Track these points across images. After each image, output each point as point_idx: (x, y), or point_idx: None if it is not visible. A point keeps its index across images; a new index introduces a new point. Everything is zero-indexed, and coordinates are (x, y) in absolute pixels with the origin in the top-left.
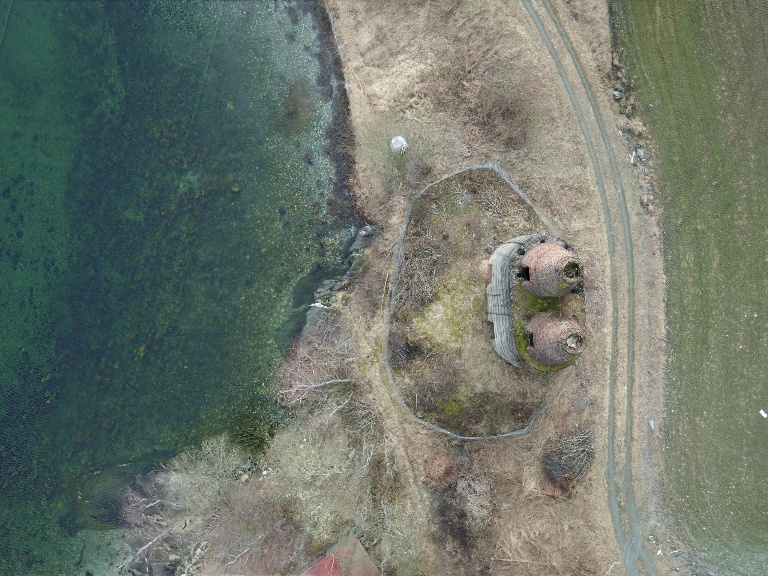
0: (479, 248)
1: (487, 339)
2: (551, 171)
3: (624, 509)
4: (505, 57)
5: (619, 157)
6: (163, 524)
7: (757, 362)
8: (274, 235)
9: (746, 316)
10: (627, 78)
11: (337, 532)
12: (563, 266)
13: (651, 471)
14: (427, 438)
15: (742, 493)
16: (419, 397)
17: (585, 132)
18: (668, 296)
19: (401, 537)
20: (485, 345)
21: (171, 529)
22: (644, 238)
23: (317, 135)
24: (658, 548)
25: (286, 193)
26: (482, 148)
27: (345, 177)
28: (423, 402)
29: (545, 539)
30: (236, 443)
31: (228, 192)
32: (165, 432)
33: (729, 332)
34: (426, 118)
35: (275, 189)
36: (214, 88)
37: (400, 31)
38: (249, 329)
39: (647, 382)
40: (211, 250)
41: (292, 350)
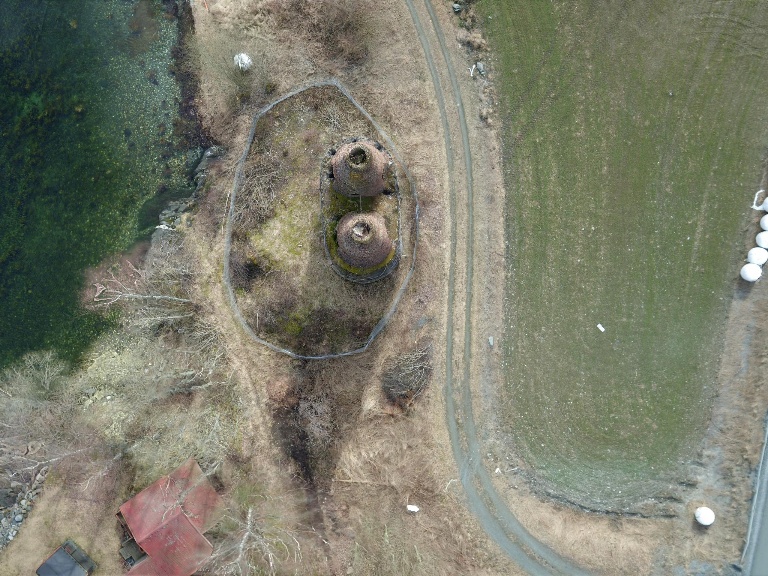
0: (316, 163)
1: (325, 255)
2: (391, 85)
3: (462, 426)
4: None
5: (458, 70)
6: (5, 450)
7: (595, 275)
8: (119, 157)
9: (584, 229)
10: None
11: (179, 456)
12: (349, 152)
13: (490, 388)
14: (270, 359)
15: (580, 409)
16: (259, 317)
17: (424, 45)
18: (507, 210)
19: (240, 458)
20: (323, 261)
21: (13, 455)
22: (484, 152)
23: (162, 55)
24: (496, 466)
25: (131, 114)
26: (326, 65)
27: (190, 97)
28: (263, 321)
29: (384, 458)
30: None
31: (73, 113)
32: (9, 358)
33: (567, 246)
34: (270, 35)
35: (120, 110)
36: (58, 7)
37: None
38: (94, 252)
39: (486, 298)
40: (56, 172)
41: (137, 273)
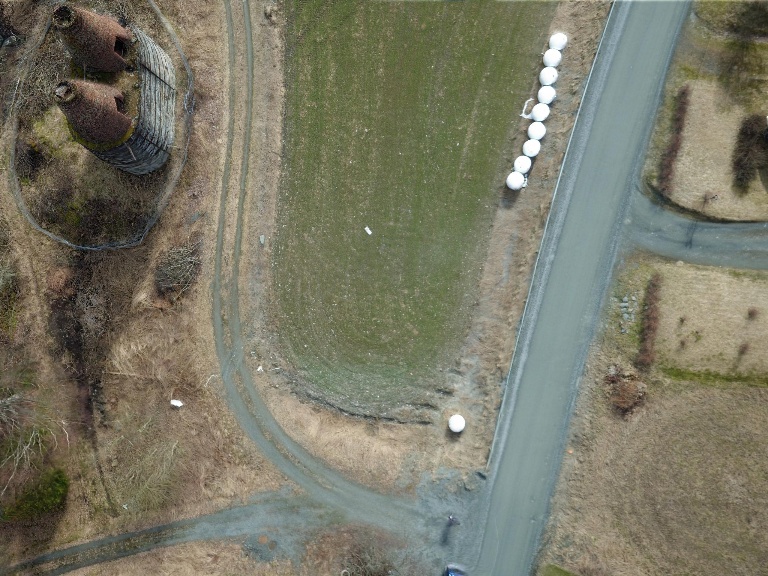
0: None
1: None
2: None
3: (227, 323)
4: None
5: None
6: None
7: (365, 178)
8: None
9: (357, 130)
10: None
11: None
12: (54, 12)
13: (259, 287)
14: (51, 249)
15: (344, 311)
16: (40, 205)
17: None
18: (285, 109)
19: (12, 345)
20: None
21: None
22: (266, 50)
23: None
24: (259, 364)
25: None
26: None
27: None
28: (43, 210)
29: (152, 352)
30: None
31: None
32: None
33: (340, 147)
34: None
35: None
36: None
37: None
38: None
39: (261, 196)
40: None
41: None
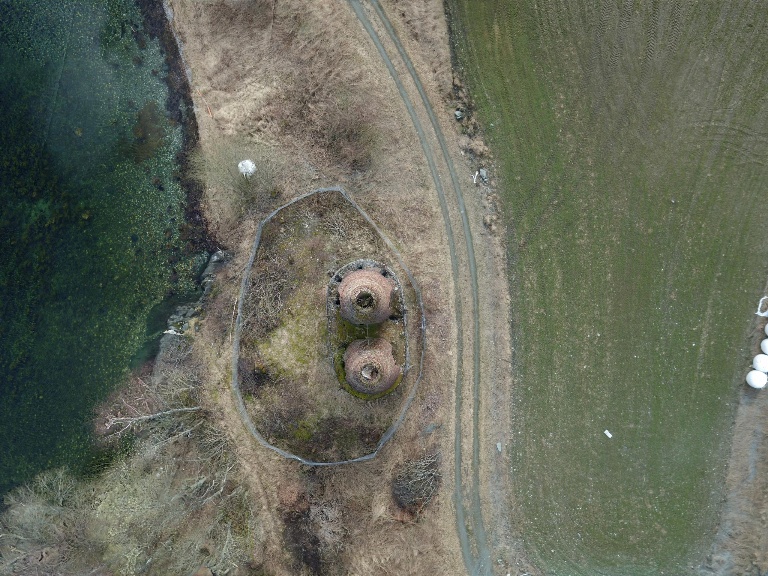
0: (322, 272)
1: None
2: (395, 193)
3: (472, 533)
4: (347, 79)
5: (461, 177)
6: None
7: (601, 382)
8: (127, 262)
9: (589, 336)
10: (468, 98)
11: (192, 561)
12: (355, 296)
13: (499, 494)
14: (280, 464)
15: (589, 514)
16: (269, 423)
17: (427, 153)
18: (513, 317)
19: (253, 565)
20: (331, 370)
21: (28, 561)
22: (488, 259)
23: (167, 160)
24: (507, 571)
25: (138, 219)
26: (329, 170)
27: (196, 202)
28: (272, 429)
29: (396, 564)
30: (93, 473)
31: (80, 220)
32: (21, 463)
33: (573, 352)
34: (274, 141)
35: (127, 216)
36: (63, 115)
37: (245, 54)
38: (104, 357)
39: (494, 404)
40: (64, 279)
41: (147, 378)
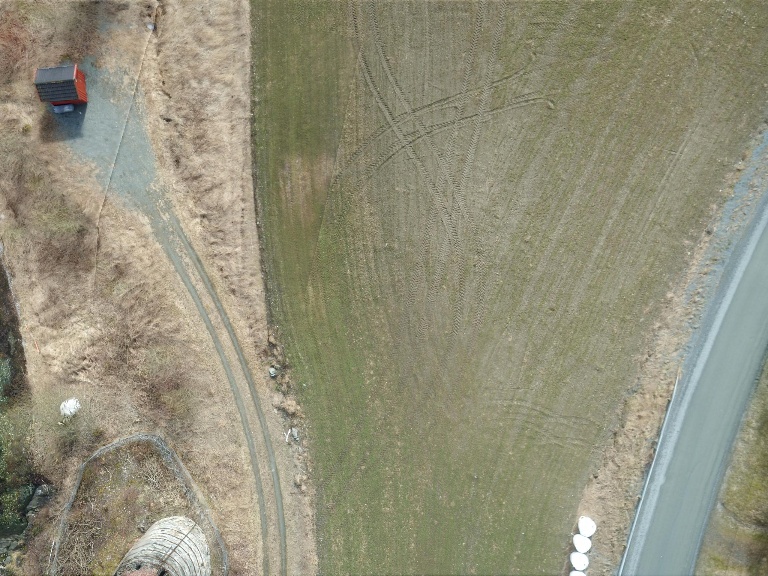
0: (133, 526)
1: None
2: (209, 446)
3: None
4: (166, 329)
5: (273, 436)
6: None
7: None
8: None
9: None
10: (282, 356)
11: None
12: None
13: None
14: None
15: None
16: None
17: (241, 409)
18: None
19: None
20: None
21: None
22: (298, 518)
23: None
24: None
25: None
26: (150, 414)
27: (22, 435)
28: None
29: None
30: None
31: None
32: None
33: None
34: (98, 381)
35: None
36: None
37: (71, 294)
38: None
39: None
40: None
41: None
